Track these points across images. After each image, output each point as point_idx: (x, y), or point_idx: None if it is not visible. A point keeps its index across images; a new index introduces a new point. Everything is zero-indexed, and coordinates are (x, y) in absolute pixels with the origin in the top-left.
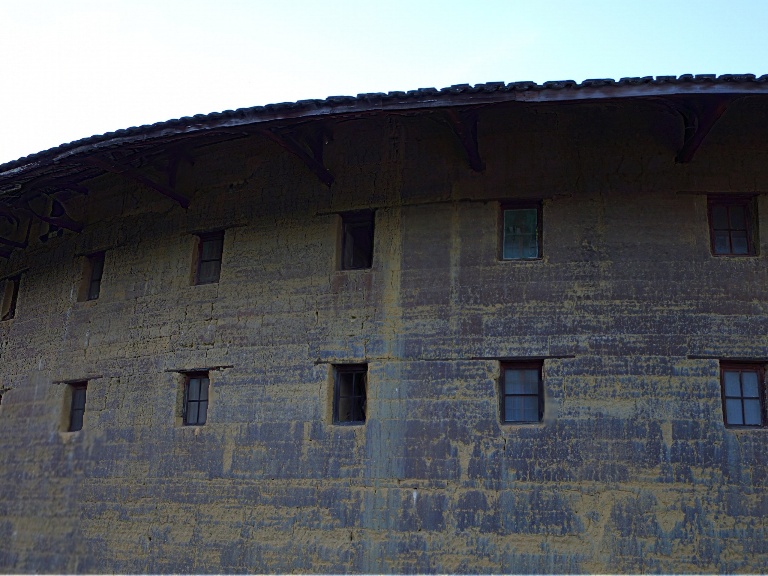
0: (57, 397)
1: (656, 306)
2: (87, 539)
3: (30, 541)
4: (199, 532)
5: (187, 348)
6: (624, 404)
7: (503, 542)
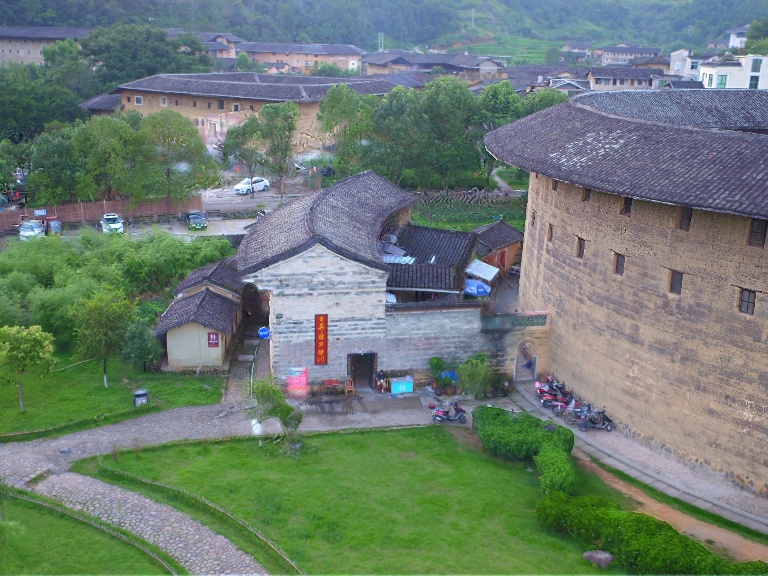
0: (664, 275)
1: None
2: (685, 348)
3: (651, 338)
4: (747, 363)
5: (744, 277)
6: None
7: None
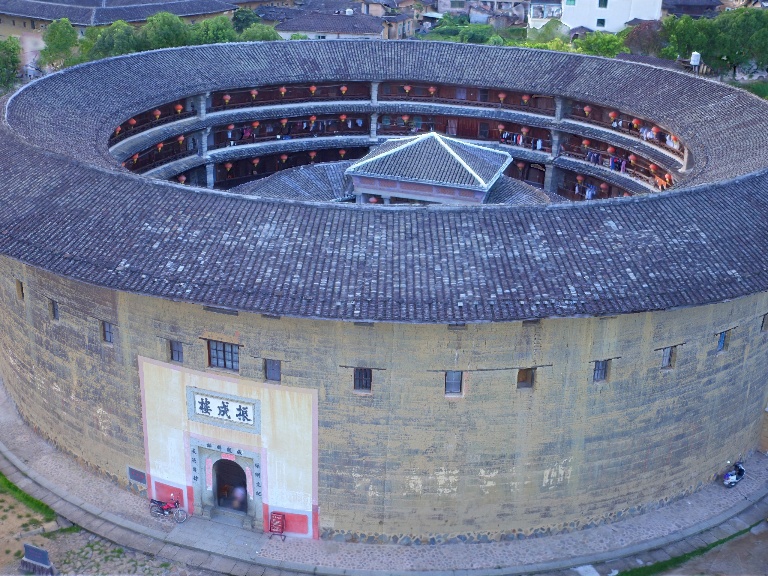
0: None
1: (82, 295)
2: None
3: None
4: None
5: None
6: (76, 326)
7: (55, 358)
